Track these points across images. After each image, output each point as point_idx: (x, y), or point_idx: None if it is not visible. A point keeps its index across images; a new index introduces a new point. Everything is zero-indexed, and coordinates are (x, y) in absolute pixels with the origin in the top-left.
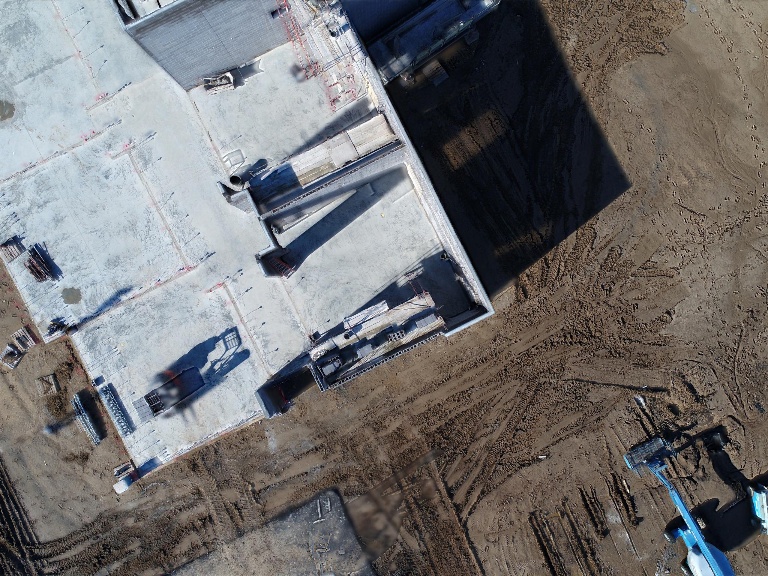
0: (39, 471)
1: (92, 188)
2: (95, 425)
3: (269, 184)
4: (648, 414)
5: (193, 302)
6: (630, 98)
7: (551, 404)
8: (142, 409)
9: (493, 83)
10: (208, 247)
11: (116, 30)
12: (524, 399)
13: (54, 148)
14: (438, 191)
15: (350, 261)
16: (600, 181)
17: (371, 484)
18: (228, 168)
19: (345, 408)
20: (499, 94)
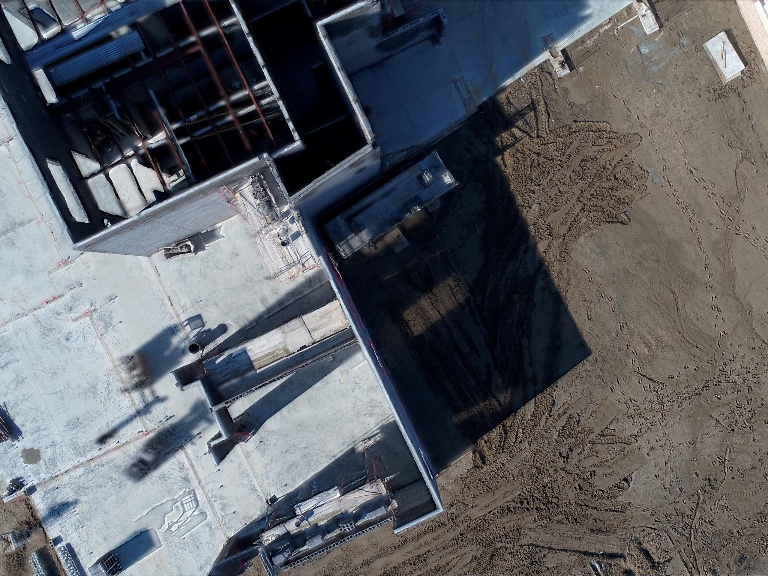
0: None
1: (53, 350)
2: None
3: (224, 367)
4: None
5: (151, 464)
6: (591, 267)
7: (507, 569)
8: (98, 575)
9: (454, 250)
10: (167, 410)
11: None
12: (480, 564)
13: (15, 310)
14: (397, 357)
15: (308, 426)
16: (559, 349)
17: None
18: (188, 332)
19: (301, 570)
20: (460, 261)
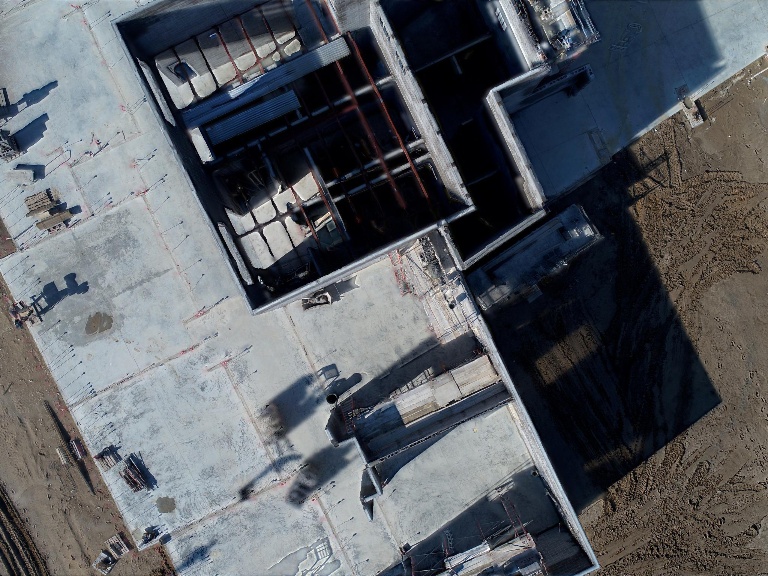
0: None
1: (188, 400)
2: None
3: (373, 422)
4: None
5: (285, 513)
6: (722, 316)
7: None
8: None
9: (586, 299)
10: (301, 459)
11: (214, 245)
12: None
13: (151, 360)
14: (529, 405)
15: (441, 475)
16: (690, 397)
17: None
18: (322, 382)
19: None
20: (592, 310)
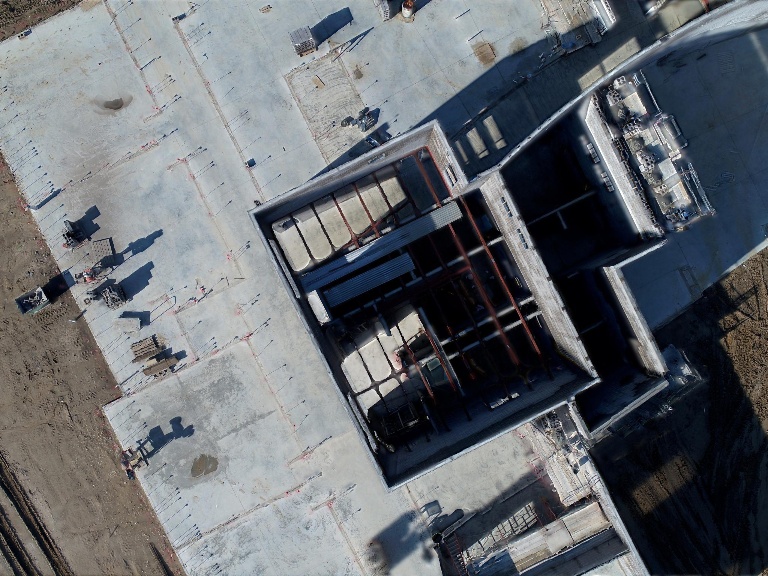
0: None
1: (293, 539)
2: None
3: (487, 570)
4: None
5: None
6: None
7: None
8: None
9: (681, 431)
10: None
11: (317, 386)
12: None
13: (256, 500)
14: None
15: None
16: None
17: None
18: (425, 518)
19: None
20: (686, 441)
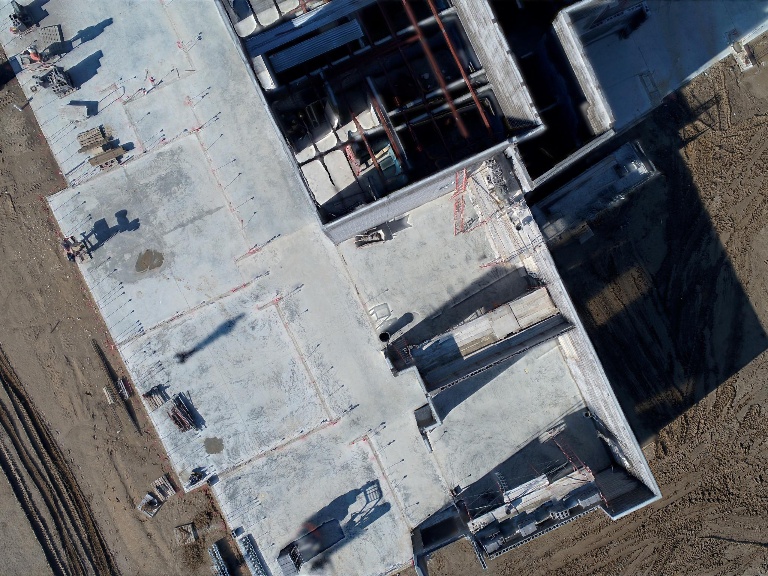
0: None
1: (238, 338)
2: (232, 575)
3: (431, 354)
4: None
5: (335, 454)
6: None
7: (688, 561)
8: (287, 566)
9: (637, 241)
10: (352, 399)
11: (267, 182)
12: (661, 556)
13: (201, 298)
14: None
15: (493, 416)
16: (741, 340)
17: None
18: (374, 321)
19: None
20: (643, 252)
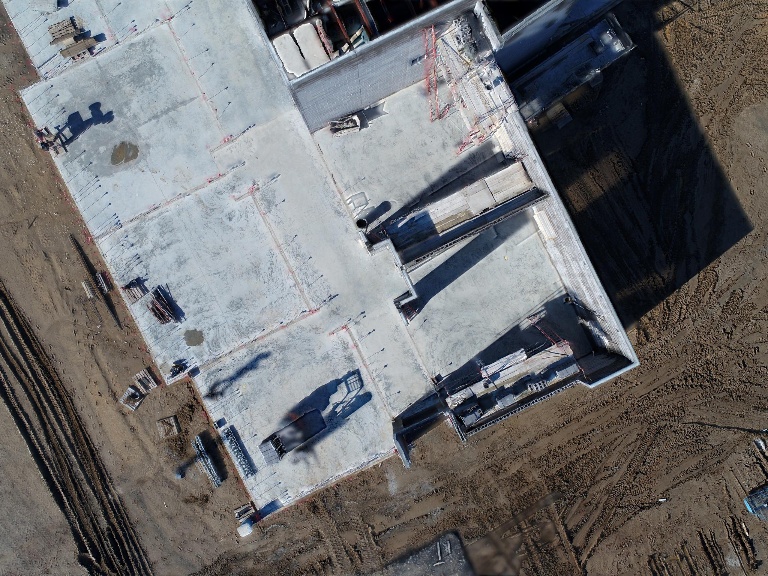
0: (159, 512)
1: (215, 230)
2: (216, 467)
3: (406, 231)
4: (767, 457)
5: (315, 344)
6: (753, 141)
7: (671, 447)
8: (268, 453)
9: (616, 126)
10: (331, 289)
11: (241, 72)
12: (644, 442)
13: (178, 190)
14: None
15: (473, 304)
16: (722, 224)
17: (491, 527)
18: (351, 210)
19: (466, 451)
20: (622, 137)
